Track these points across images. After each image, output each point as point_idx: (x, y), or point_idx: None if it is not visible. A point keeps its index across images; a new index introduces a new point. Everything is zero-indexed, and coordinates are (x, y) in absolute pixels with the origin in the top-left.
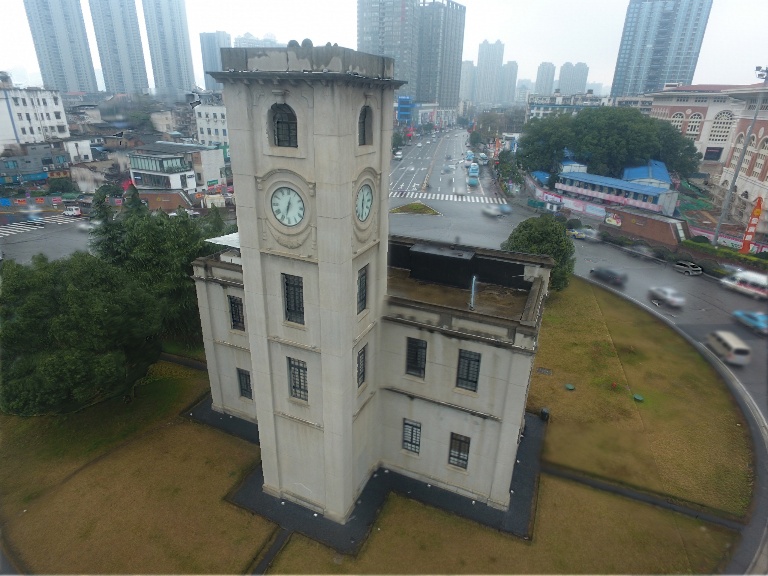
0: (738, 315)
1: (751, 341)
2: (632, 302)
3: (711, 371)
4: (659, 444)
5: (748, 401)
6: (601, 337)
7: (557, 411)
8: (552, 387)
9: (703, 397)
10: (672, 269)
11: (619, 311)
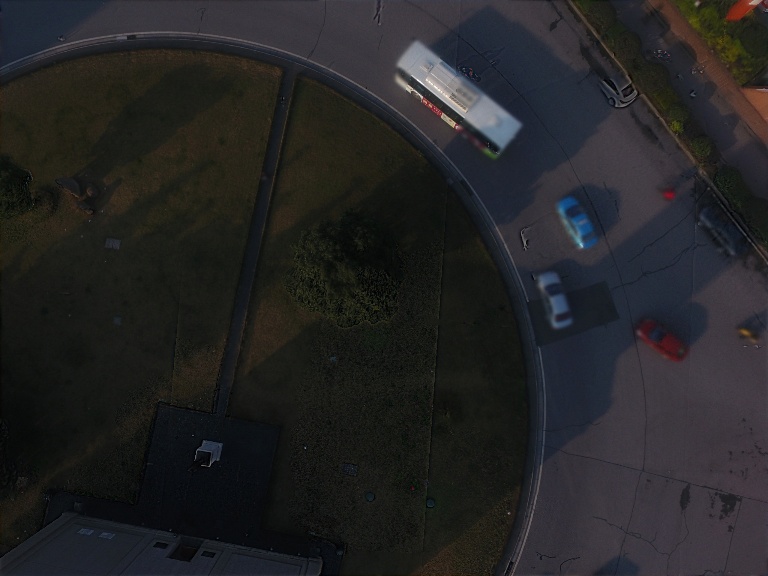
0: (619, 253)
1: (601, 329)
2: (490, 256)
3: (523, 421)
4: (429, 567)
5: (537, 466)
6: (423, 380)
7: (353, 538)
8: (353, 500)
9: (494, 480)
10: (596, 83)
11: (465, 290)
